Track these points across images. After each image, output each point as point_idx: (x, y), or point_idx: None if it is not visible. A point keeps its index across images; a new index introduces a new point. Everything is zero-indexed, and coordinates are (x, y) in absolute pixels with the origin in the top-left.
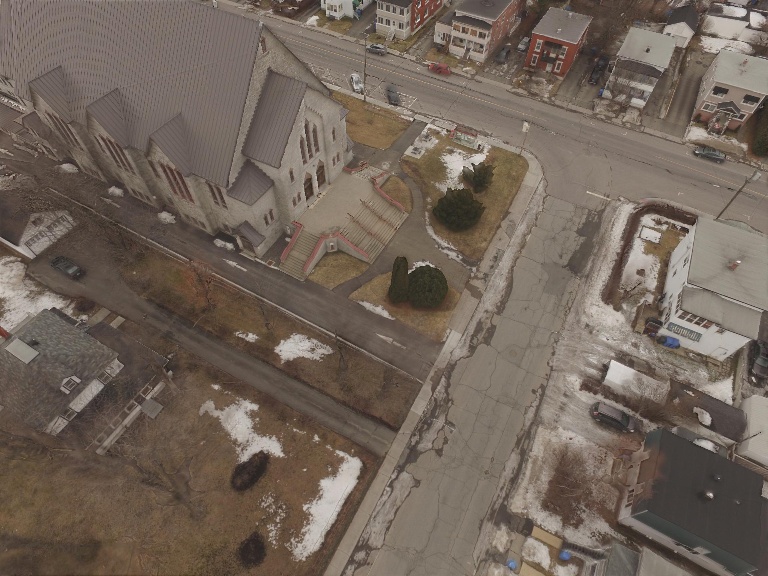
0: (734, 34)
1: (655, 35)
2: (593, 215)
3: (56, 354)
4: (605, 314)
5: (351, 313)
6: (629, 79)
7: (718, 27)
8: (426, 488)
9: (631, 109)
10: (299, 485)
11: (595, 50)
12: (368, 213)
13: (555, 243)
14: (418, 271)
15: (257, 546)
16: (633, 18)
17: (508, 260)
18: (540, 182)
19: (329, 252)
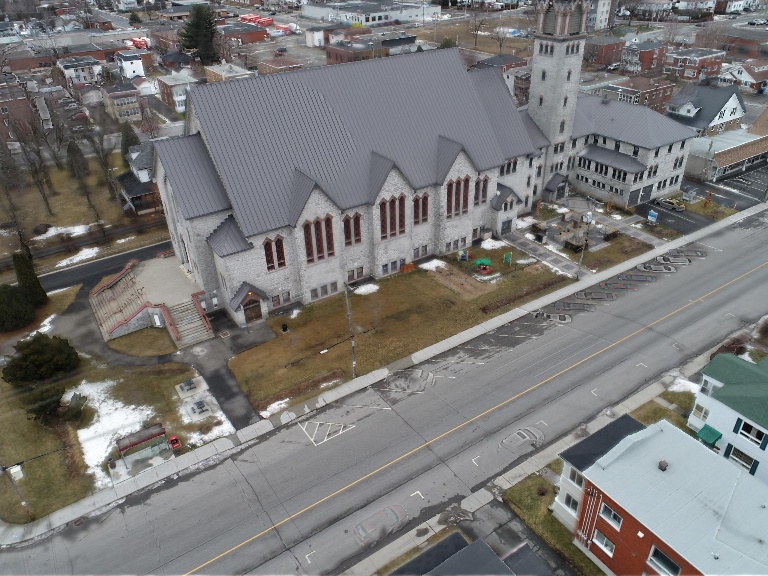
0: None
1: None
2: None
3: (148, 147)
4: None
5: (68, 281)
6: None
7: None
8: None
9: None
10: (7, 241)
11: None
12: None
13: None
14: None
15: (6, 226)
16: None
17: None
18: None
19: None
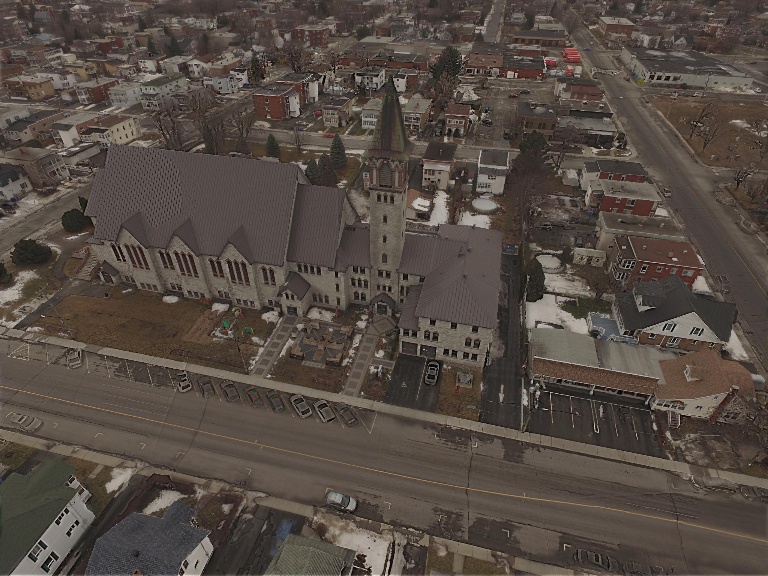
0: None
1: None
2: None
3: None
4: None
5: None
6: None
7: None
8: None
9: None
10: None
11: None
12: None
13: None
14: None
15: None
16: None
17: None
18: None
19: None
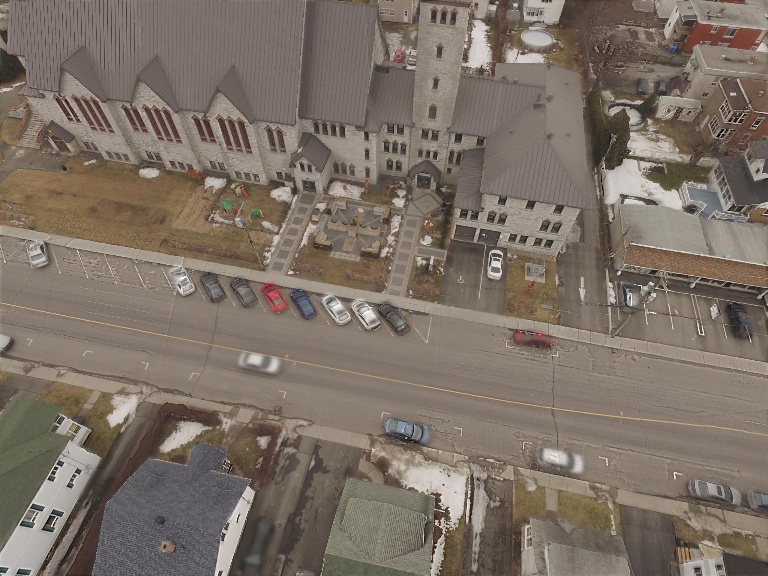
0: None
1: None
2: None
3: None
4: None
5: None
6: None
7: None
8: None
9: None
10: None
11: None
12: None
13: None
14: (0, 52)
15: None
16: None
17: None
18: None
19: None
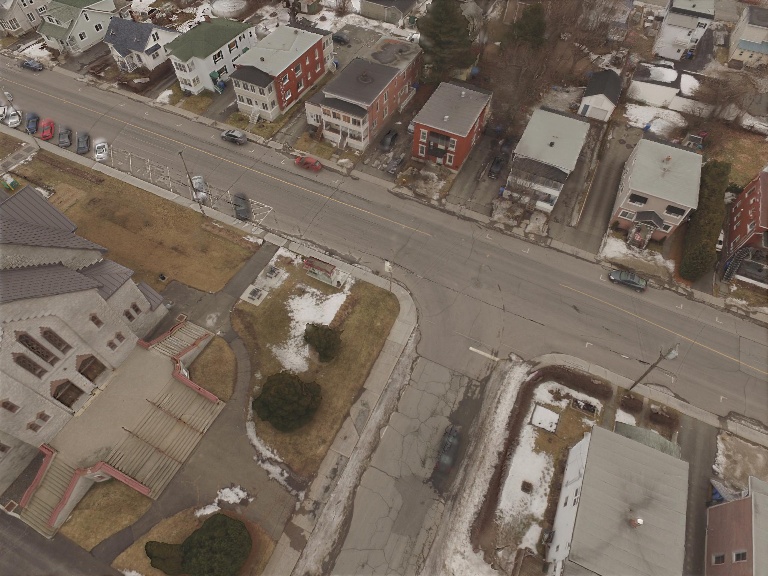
0: (664, 102)
1: (563, 120)
2: (474, 387)
3: None
4: (471, 571)
5: None
6: (530, 181)
7: (645, 93)
8: None
9: (536, 214)
10: None
11: (499, 130)
12: (160, 415)
13: (419, 439)
14: (194, 542)
15: None
16: (549, 82)
17: (351, 475)
18: (411, 335)
19: (99, 482)
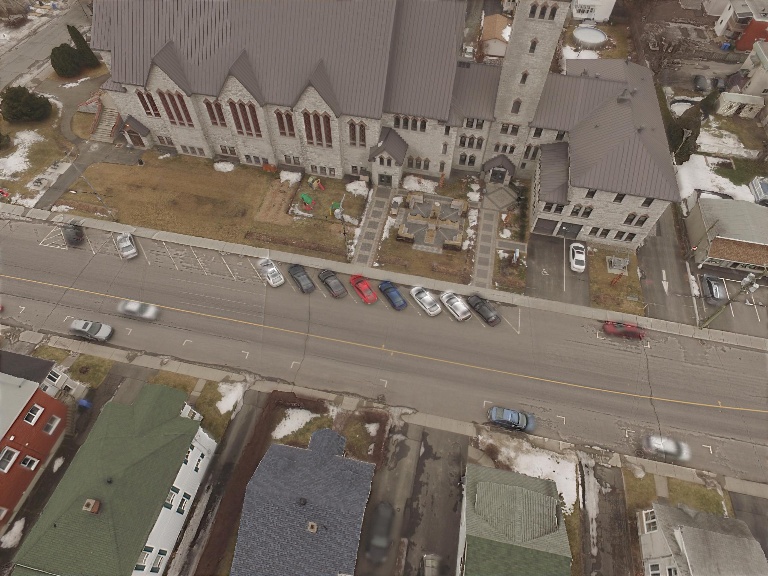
0: None
1: None
2: None
3: None
4: None
5: None
6: None
7: None
8: (90, 18)
9: None
10: None
11: None
12: None
13: None
14: None
15: None
16: None
17: None
18: None
19: None
